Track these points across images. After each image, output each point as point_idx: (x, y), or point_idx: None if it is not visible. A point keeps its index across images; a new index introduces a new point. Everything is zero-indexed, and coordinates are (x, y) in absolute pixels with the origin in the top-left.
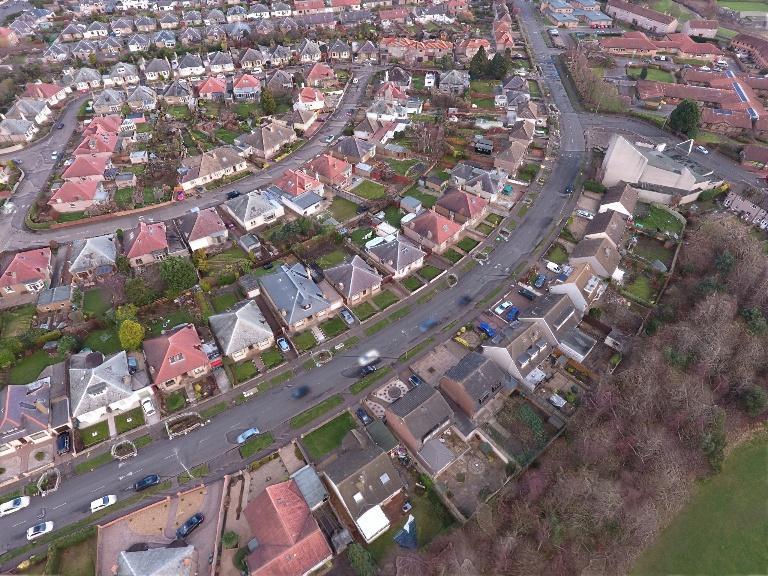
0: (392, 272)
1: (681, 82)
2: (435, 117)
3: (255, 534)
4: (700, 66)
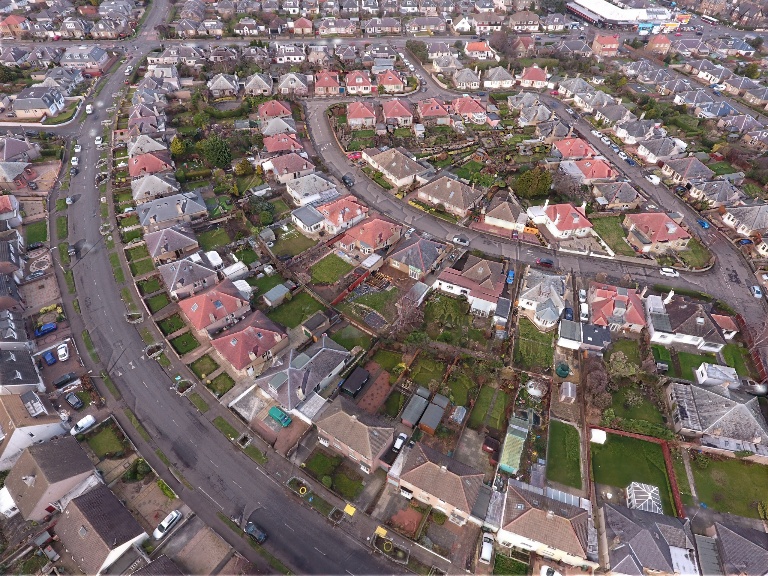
0: None
1: None
2: None
3: None
4: None
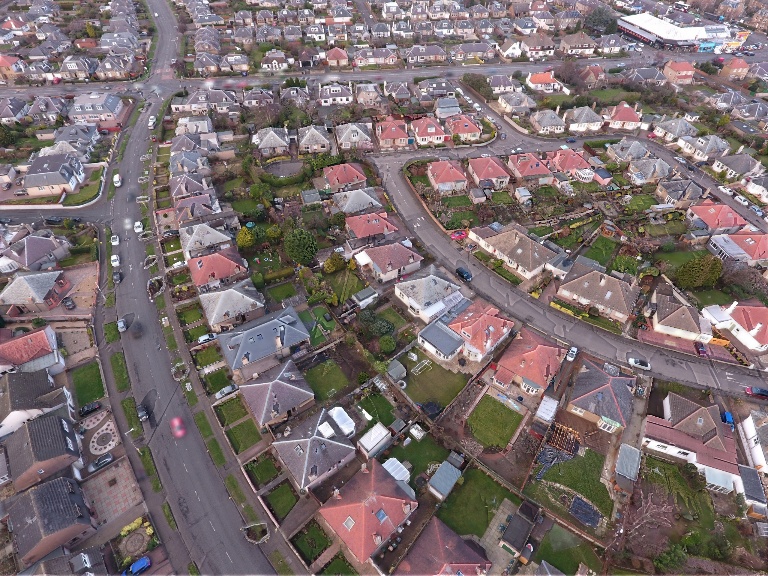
0: None
1: None
2: None
3: None
4: None
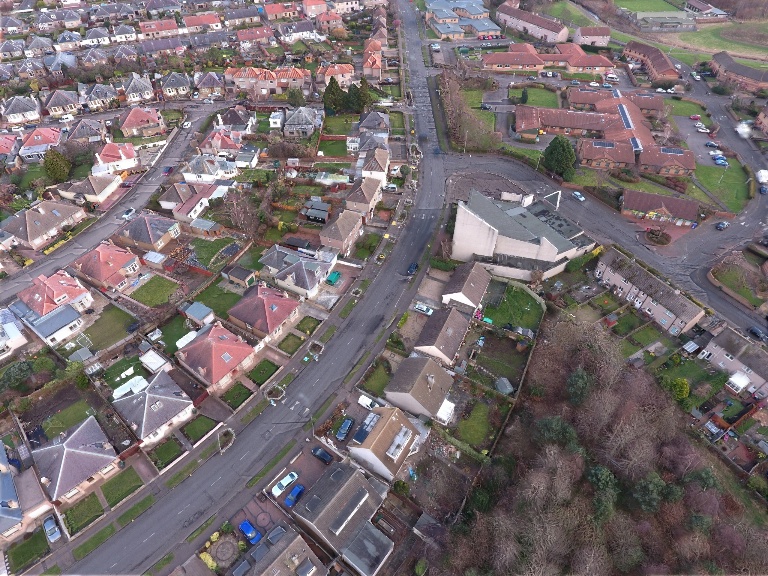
0: None
1: (565, 104)
2: (266, 174)
3: None
4: (589, 82)
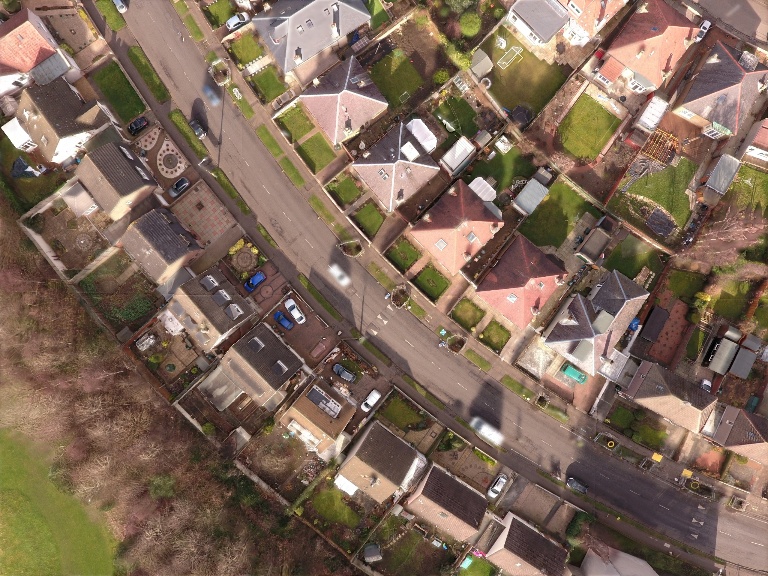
0: None
1: None
2: None
3: (4, 23)
4: None
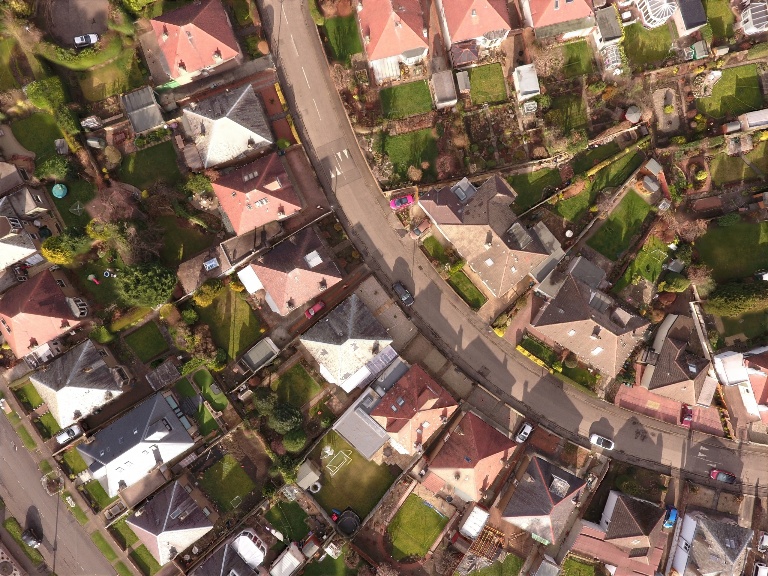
0: (189, 573)
1: None
2: None
3: None
4: None
